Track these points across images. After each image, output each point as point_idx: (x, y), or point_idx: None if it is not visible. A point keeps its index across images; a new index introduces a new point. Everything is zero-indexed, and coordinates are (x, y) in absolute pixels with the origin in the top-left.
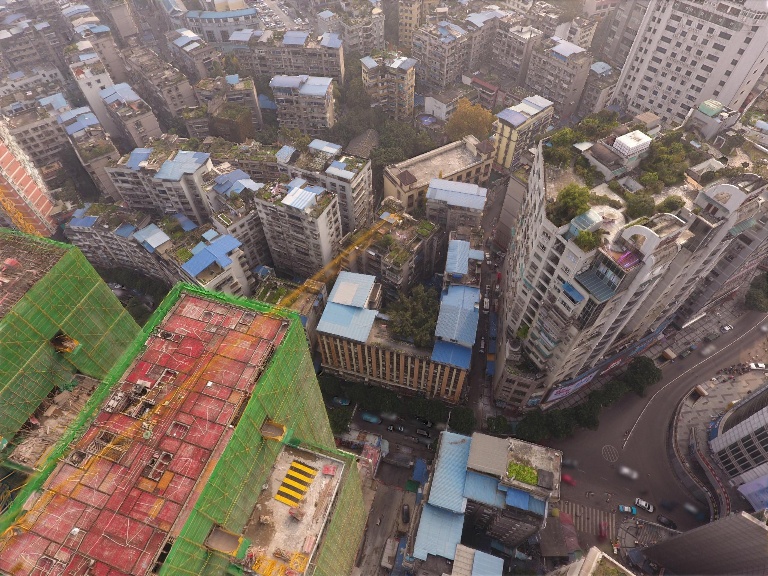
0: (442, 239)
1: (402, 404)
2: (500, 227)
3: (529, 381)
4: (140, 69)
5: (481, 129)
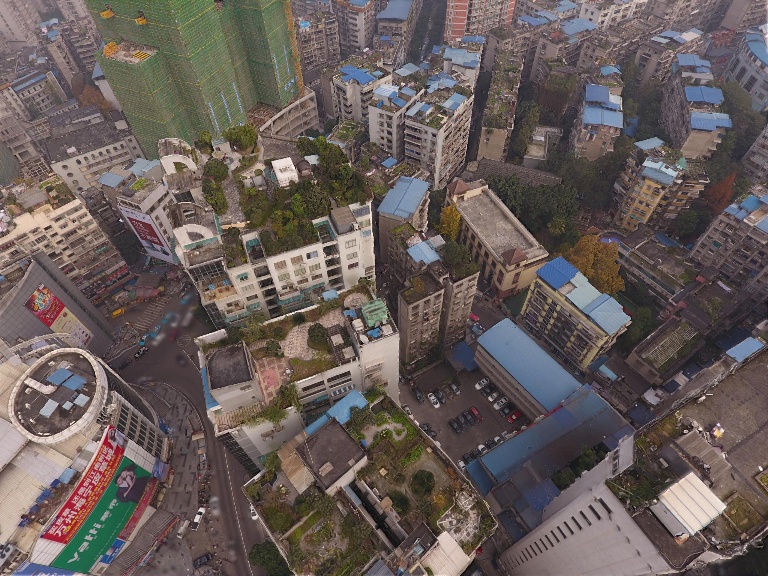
0: (375, 209)
1: None
2: None
3: None
4: (616, 26)
5: None
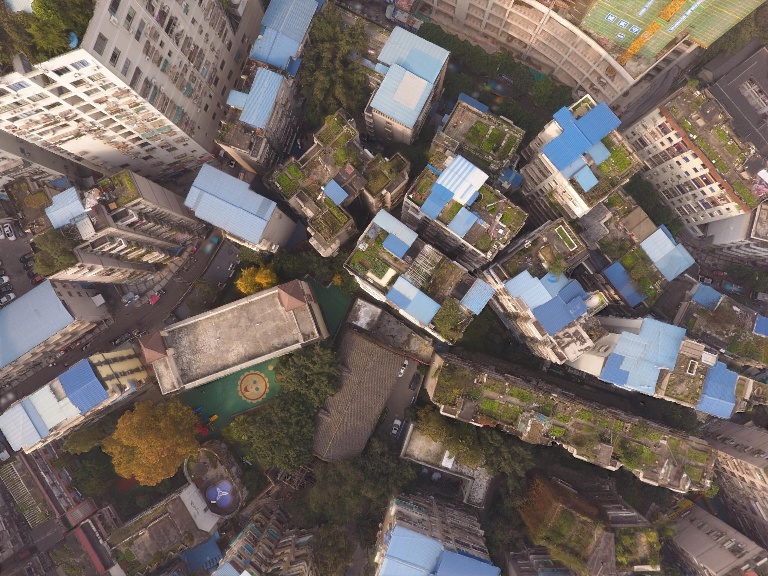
0: None
1: None
2: (187, 213)
3: None
4: None
5: (142, 411)
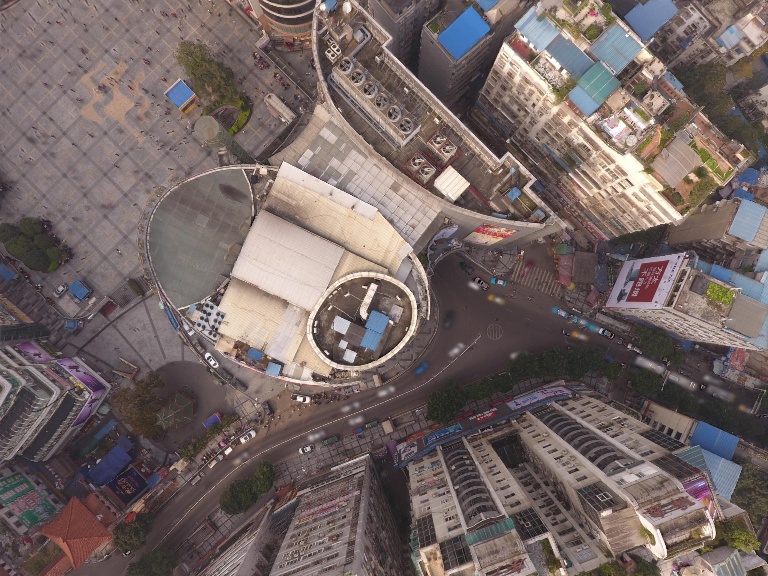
0: None
1: (705, 407)
2: None
3: (617, 402)
4: None
5: None
